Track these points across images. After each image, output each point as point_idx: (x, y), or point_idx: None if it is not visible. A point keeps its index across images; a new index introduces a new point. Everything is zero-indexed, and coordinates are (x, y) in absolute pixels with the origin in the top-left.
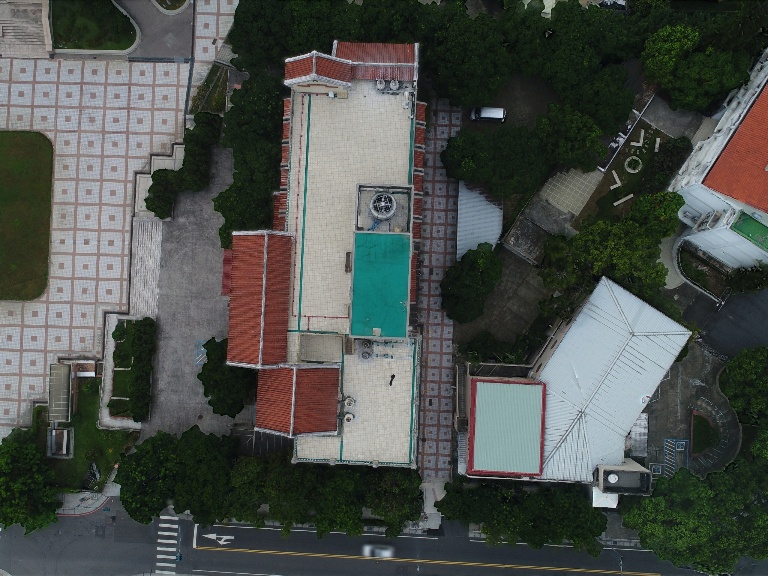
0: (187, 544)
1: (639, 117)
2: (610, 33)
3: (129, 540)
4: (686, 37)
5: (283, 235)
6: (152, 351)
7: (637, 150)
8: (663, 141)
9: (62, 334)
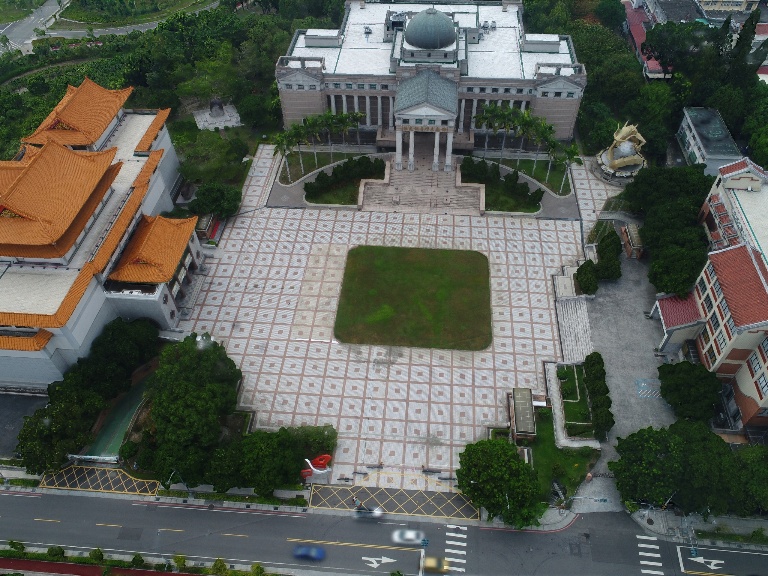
0: (674, 567)
1: None
2: None
3: (609, 560)
4: None
5: (754, 250)
6: (604, 379)
7: None
8: None
9: (508, 376)
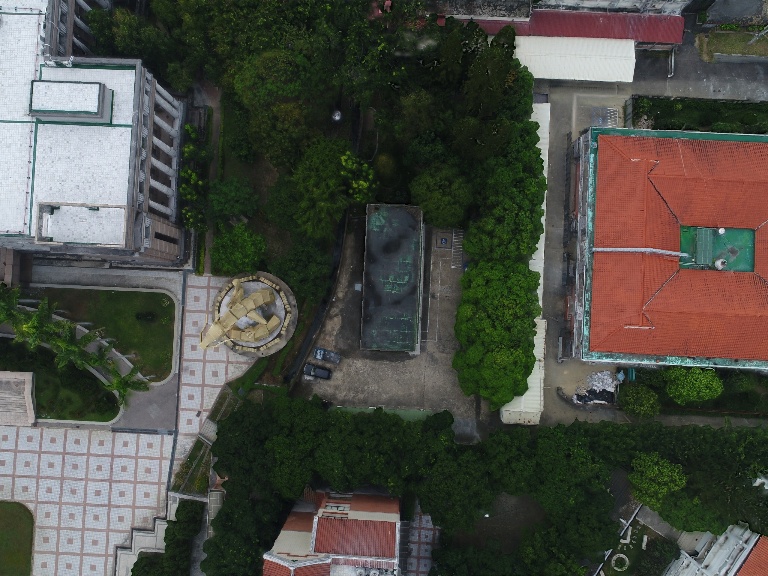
0: None
1: (626, 527)
2: (596, 481)
3: None
4: (673, 482)
5: None
6: None
7: (624, 546)
8: (651, 538)
9: None
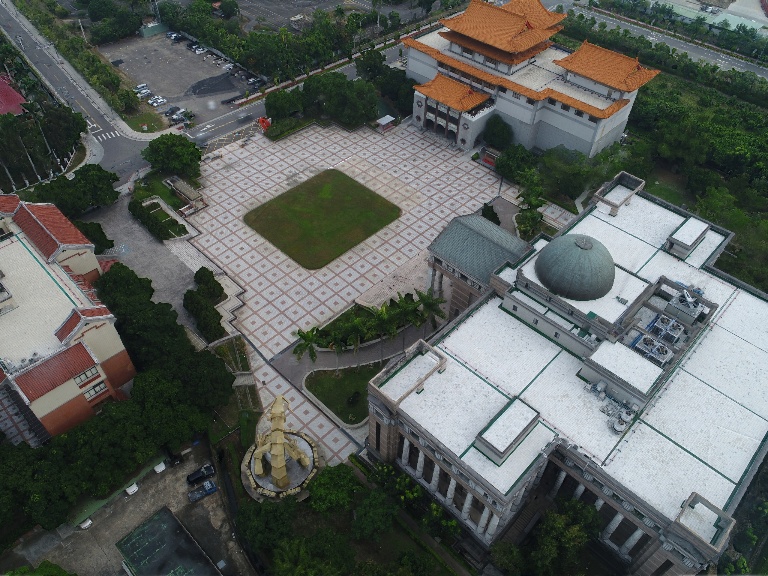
0: None
1: None
2: None
3: None
4: None
5: None
6: None
7: None
8: None
9: (216, 213)
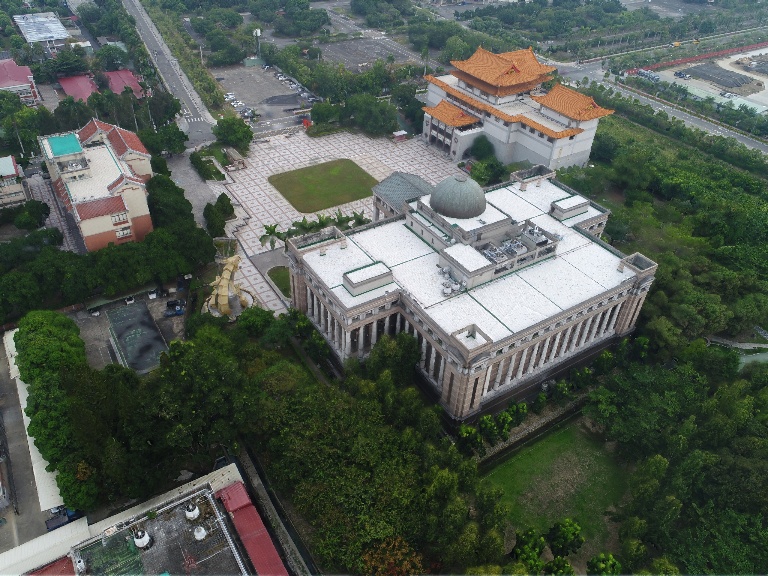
0: None
1: None
2: None
3: None
4: None
5: None
6: None
7: None
8: None
9: None
